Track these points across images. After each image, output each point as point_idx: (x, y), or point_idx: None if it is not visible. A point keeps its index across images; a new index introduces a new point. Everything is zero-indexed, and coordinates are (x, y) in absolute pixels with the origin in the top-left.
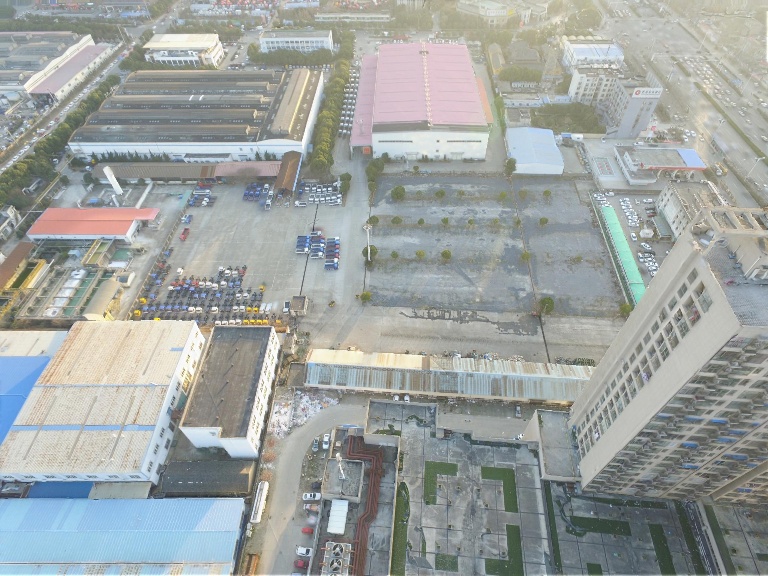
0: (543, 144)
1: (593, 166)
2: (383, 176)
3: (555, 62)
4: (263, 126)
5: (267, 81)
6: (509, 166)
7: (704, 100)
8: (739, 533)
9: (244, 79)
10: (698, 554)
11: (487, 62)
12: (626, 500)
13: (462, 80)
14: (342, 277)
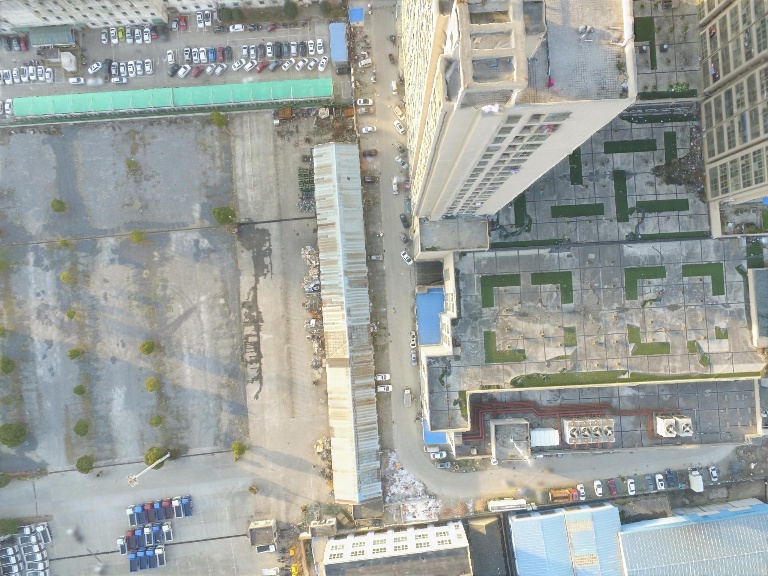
0: None
1: None
2: None
3: None
4: None
5: None
6: None
7: None
8: None
9: None
10: None
11: None
12: None
13: None
14: (204, 486)
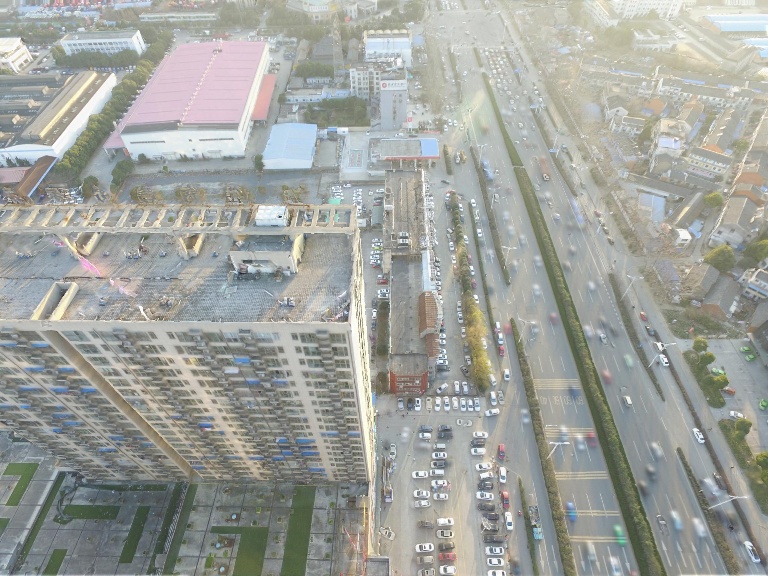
0: (298, 139)
1: (342, 159)
2: (136, 177)
3: (342, 57)
4: (21, 131)
5: (45, 85)
6: (255, 162)
7: (483, 90)
8: (208, 508)
9: (26, 84)
10: (167, 531)
11: (294, 58)
12: (131, 485)
13: (240, 78)
14: None
